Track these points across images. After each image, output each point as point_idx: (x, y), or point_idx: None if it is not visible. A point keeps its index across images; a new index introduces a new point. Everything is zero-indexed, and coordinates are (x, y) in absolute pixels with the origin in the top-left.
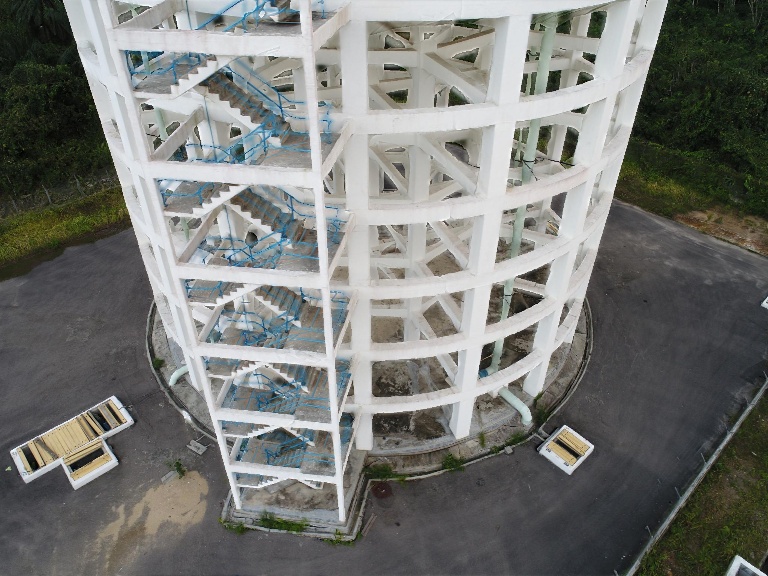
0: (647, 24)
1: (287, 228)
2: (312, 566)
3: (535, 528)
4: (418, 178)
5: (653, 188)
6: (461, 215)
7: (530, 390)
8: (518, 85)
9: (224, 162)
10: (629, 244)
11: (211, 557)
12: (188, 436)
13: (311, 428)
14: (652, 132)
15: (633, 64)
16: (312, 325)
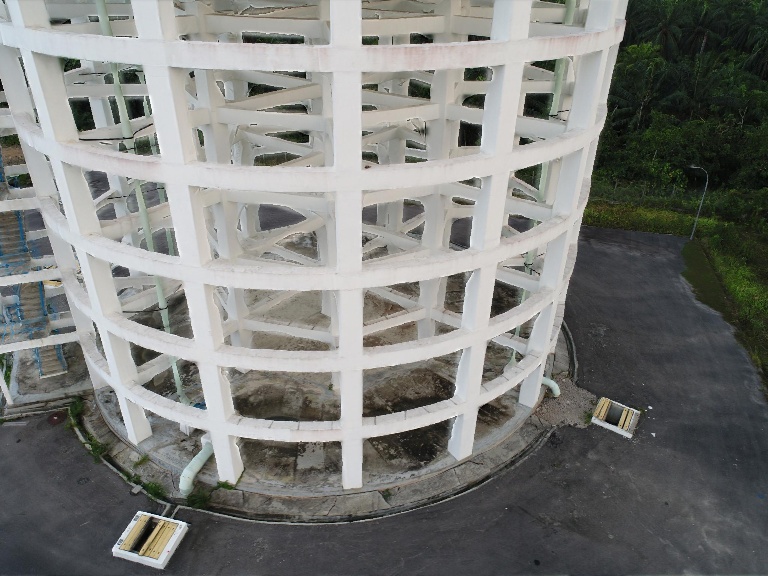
0: None
1: None
2: None
3: (26, 545)
4: (208, 158)
5: None
6: None
7: None
8: (17, 6)
9: None
10: (680, 507)
11: None
12: None
13: None
14: None
15: (223, 43)
16: None
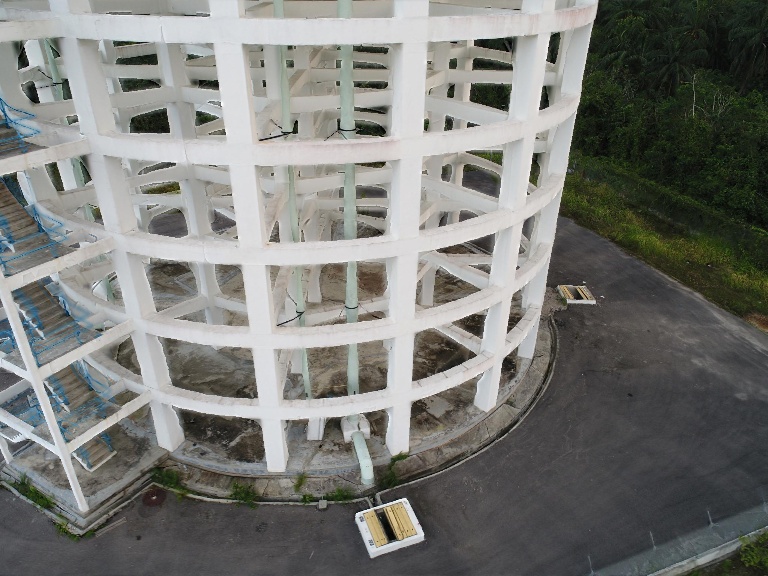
0: None
1: None
2: (23, 546)
3: None
4: None
5: (738, 279)
6: (198, 159)
7: (390, 445)
8: None
9: (3, 74)
10: (656, 330)
11: None
12: None
13: (16, 373)
14: (767, 218)
15: (470, 16)
16: (26, 253)
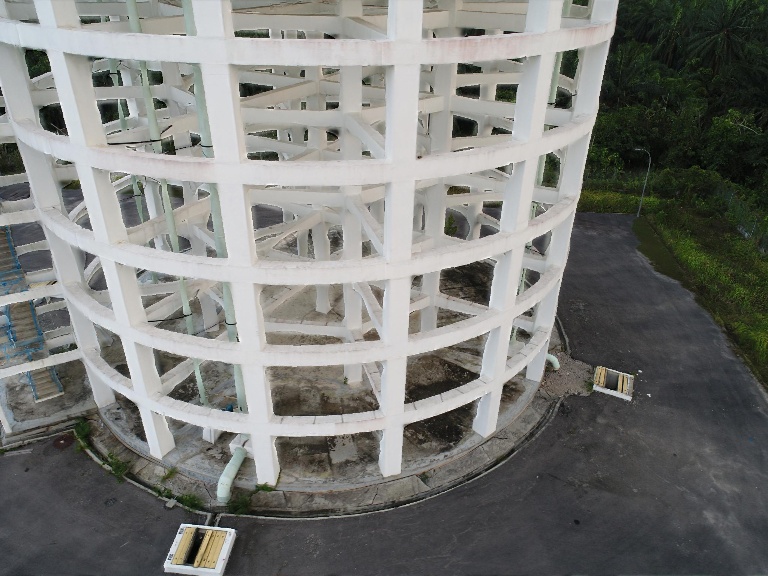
0: (390, 5)
1: None
2: None
3: (66, 574)
4: None
5: None
6: (57, 153)
7: None
8: (49, 5)
9: None
10: (687, 457)
11: None
12: (69, 323)
13: None
14: None
15: None
16: None
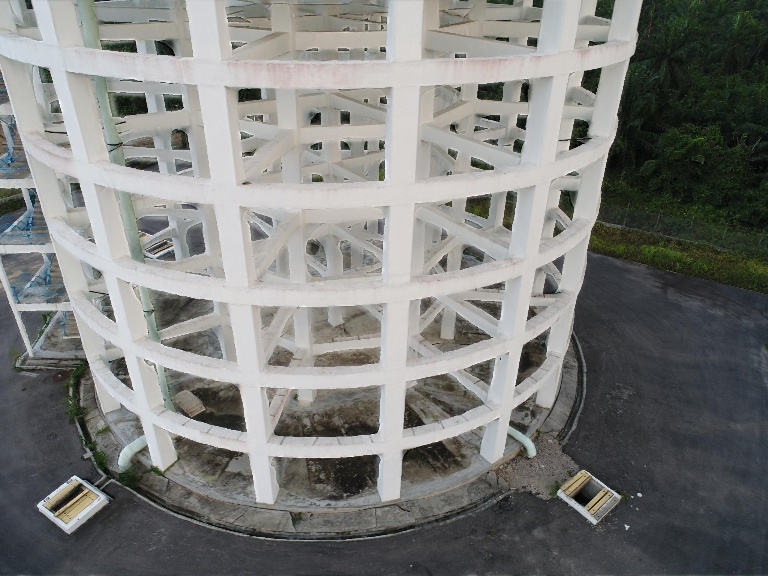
0: None
1: (2, 88)
2: (4, 354)
3: None
4: None
5: None
6: None
7: None
8: None
9: None
10: None
11: (31, 312)
12: None
13: None
14: None
15: (105, 51)
16: (11, 171)
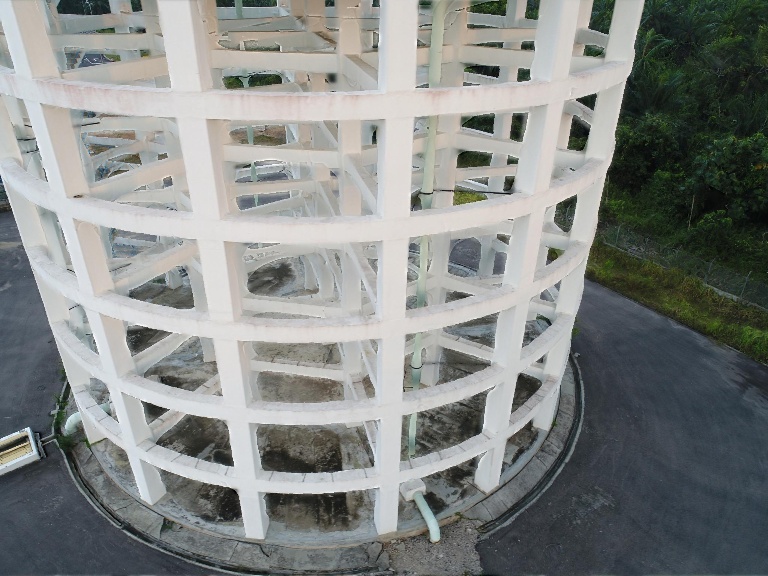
0: None
1: None
2: None
3: None
4: None
5: None
6: None
7: None
8: None
9: None
10: None
11: None
12: None
13: None
14: None
15: None
16: None
